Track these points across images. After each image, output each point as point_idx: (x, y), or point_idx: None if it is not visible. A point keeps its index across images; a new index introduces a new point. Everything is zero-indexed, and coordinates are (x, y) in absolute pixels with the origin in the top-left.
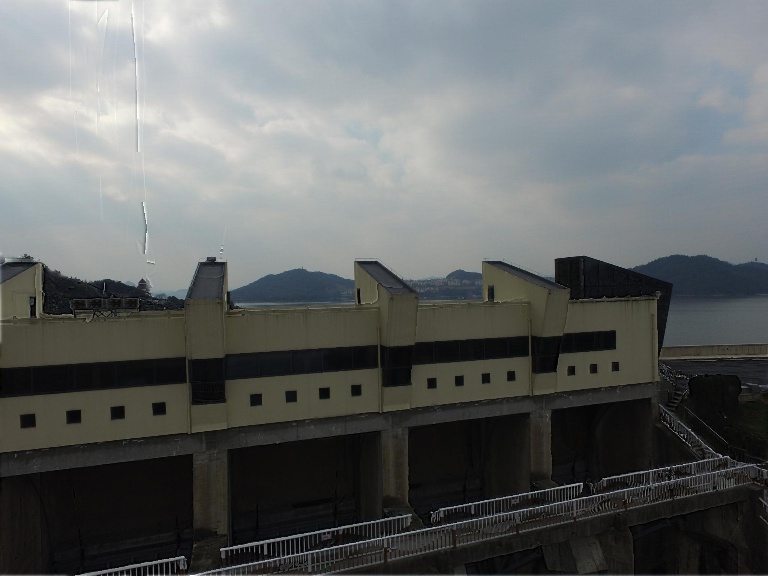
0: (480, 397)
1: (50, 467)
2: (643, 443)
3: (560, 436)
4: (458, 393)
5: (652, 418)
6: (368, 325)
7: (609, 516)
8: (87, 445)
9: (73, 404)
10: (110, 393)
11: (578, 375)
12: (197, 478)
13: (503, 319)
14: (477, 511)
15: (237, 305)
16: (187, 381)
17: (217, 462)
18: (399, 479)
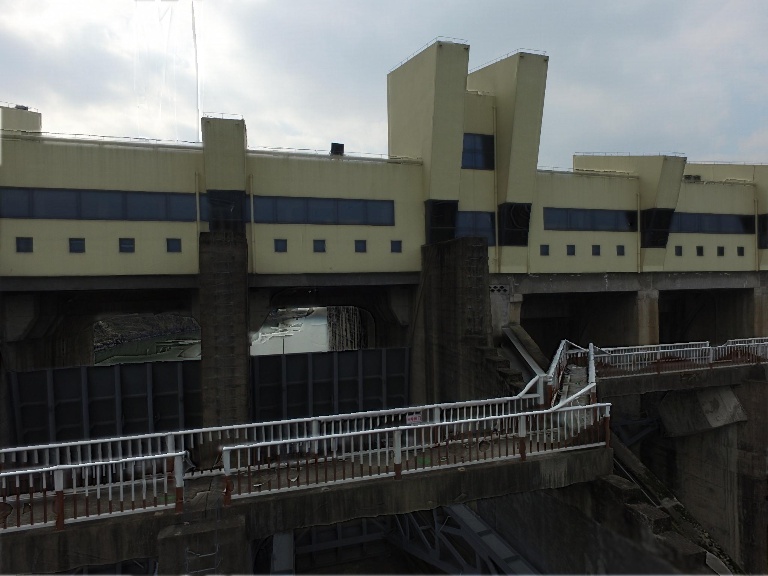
0: None
1: (685, 286)
2: None
3: None
4: None
5: None
6: None
7: None
8: (703, 273)
9: (699, 242)
10: (717, 236)
11: None
12: (756, 306)
13: None
14: None
15: None
16: (756, 232)
17: (766, 296)
18: None
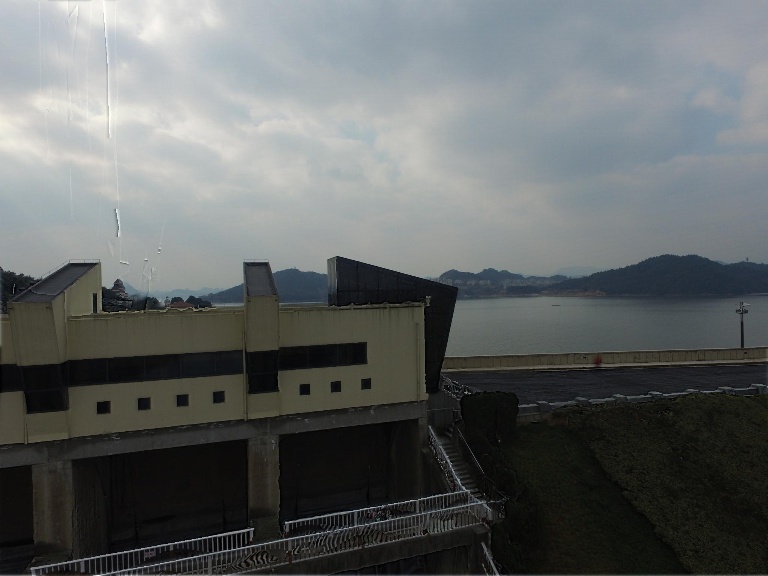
0: (175, 422)
1: None
2: (416, 469)
3: (373, 456)
4: (142, 418)
5: (420, 442)
6: (10, 339)
7: (263, 572)
8: None
9: None
10: None
11: (314, 394)
12: None
13: (208, 331)
14: (90, 568)
15: (212, 306)
16: None
17: None
18: (58, 522)
